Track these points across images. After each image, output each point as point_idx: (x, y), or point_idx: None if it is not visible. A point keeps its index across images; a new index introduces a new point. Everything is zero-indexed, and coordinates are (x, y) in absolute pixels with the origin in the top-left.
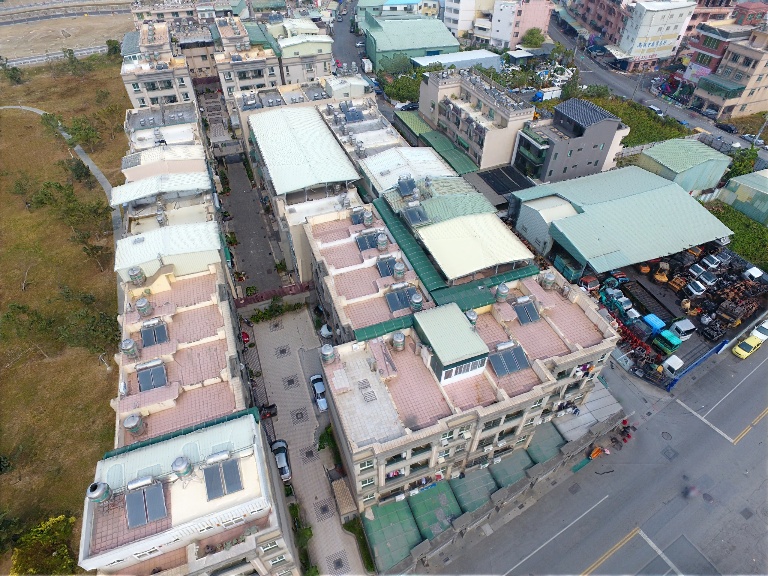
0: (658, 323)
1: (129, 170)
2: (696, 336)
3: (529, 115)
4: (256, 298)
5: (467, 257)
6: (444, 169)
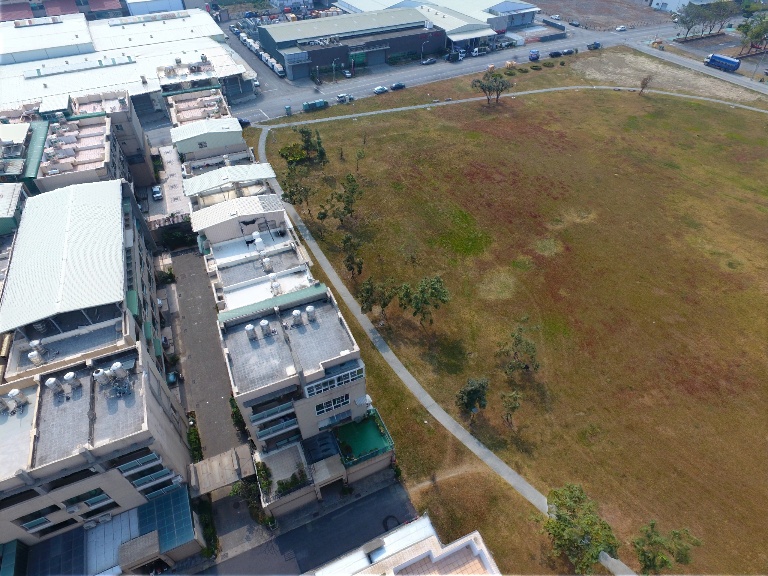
0: None
1: (270, 195)
2: None
3: None
4: None
5: (5, 129)
6: None
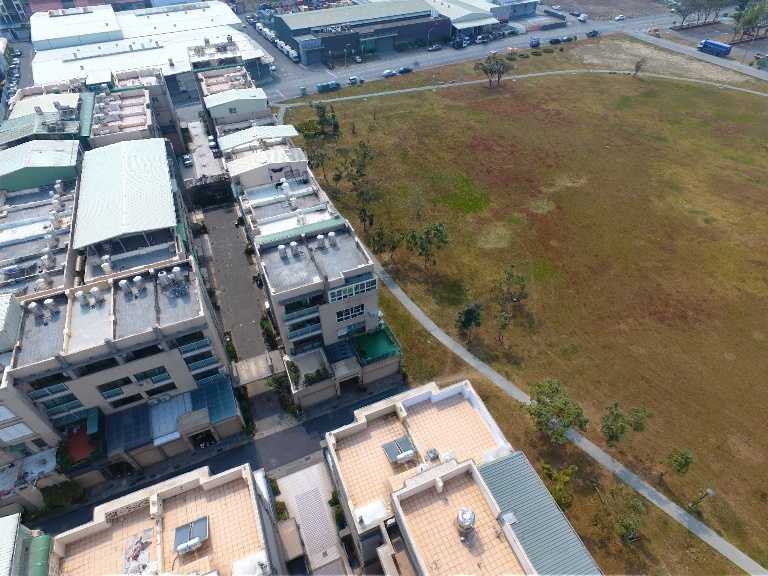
0: None
1: None
2: None
3: None
4: None
5: None
6: (0, 156)
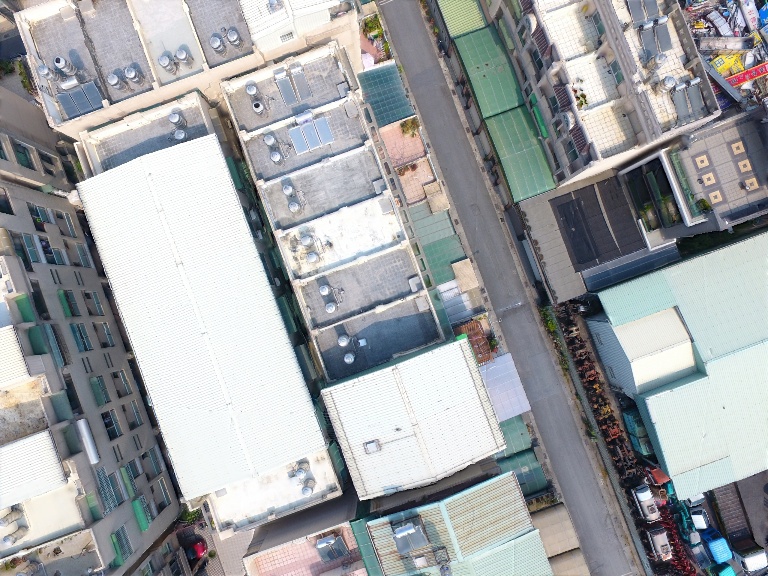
0: (723, 557)
1: None
2: (763, 545)
3: (699, 124)
4: (201, 520)
5: None
6: (482, 431)
